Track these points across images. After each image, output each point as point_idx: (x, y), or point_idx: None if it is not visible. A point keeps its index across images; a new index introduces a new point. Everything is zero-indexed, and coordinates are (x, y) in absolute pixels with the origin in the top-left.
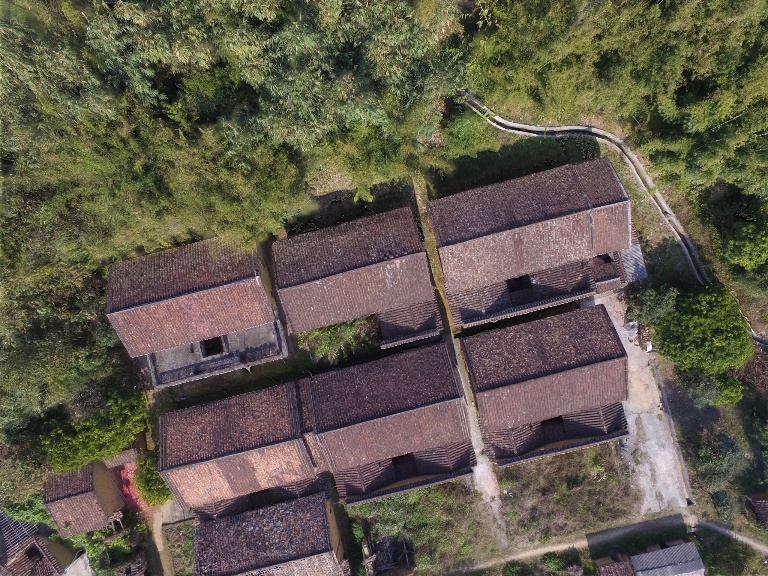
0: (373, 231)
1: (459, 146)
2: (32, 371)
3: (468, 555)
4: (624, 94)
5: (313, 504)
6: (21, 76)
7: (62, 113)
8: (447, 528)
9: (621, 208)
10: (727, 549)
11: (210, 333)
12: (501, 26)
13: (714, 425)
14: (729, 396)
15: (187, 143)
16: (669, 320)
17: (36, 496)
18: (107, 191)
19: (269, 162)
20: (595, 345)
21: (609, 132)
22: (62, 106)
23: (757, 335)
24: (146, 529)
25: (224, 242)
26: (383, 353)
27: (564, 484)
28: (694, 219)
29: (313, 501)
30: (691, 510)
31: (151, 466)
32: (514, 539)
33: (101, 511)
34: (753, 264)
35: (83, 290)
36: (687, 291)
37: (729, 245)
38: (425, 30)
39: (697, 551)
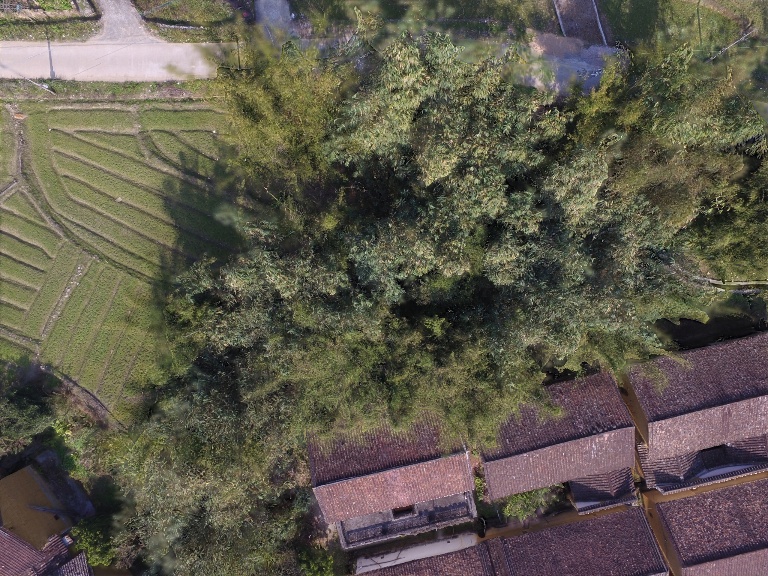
0: (575, 399)
1: None
2: (252, 558)
3: None
4: None
5: None
6: (278, 285)
7: (321, 324)
8: None
9: None
10: None
11: (409, 501)
12: (740, 221)
13: None
14: None
15: (456, 363)
16: None
17: None
18: (351, 392)
19: (517, 365)
20: None
21: None
22: (322, 318)
23: None
24: None
25: None
26: None
27: None
28: None
29: None
30: None
31: None
32: None
33: None
34: None
35: (282, 457)
36: None
37: None
38: (668, 227)
39: None
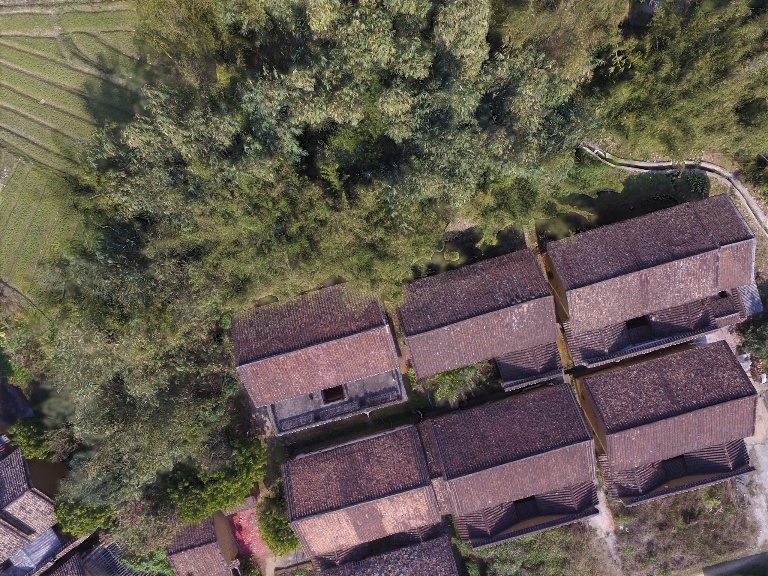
0: (496, 274)
1: (575, 185)
2: (172, 429)
3: None
4: (760, 136)
5: (438, 548)
6: (175, 140)
7: (217, 176)
8: (564, 566)
9: (746, 246)
10: None
11: (335, 381)
12: (639, 73)
13: None
14: None
15: (349, 205)
16: None
17: (158, 548)
18: (255, 250)
19: (418, 217)
20: (723, 383)
21: (719, 166)
22: (218, 170)
23: None
24: (259, 574)
25: (347, 289)
26: (495, 392)
27: (680, 518)
28: None
29: (437, 545)
30: None
31: (279, 516)
32: (631, 575)
33: (224, 561)
34: None
35: (207, 342)
36: None
37: None
38: (566, 80)
39: None
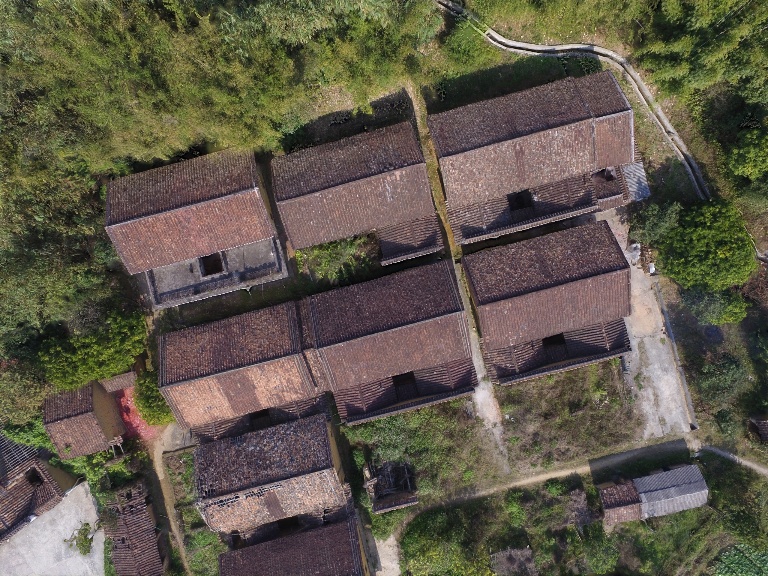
0: (373, 145)
1: (459, 61)
2: (30, 278)
3: (470, 481)
4: None
5: (314, 424)
6: None
7: (57, 3)
8: (449, 453)
9: (624, 118)
10: (731, 473)
11: (209, 249)
12: None
13: (718, 348)
14: (733, 313)
15: (184, 29)
16: (672, 237)
17: (36, 418)
18: (103, 88)
19: (267, 57)
20: (597, 258)
21: (611, 50)
22: None
23: (761, 255)
24: (147, 457)
25: (223, 157)
26: None
27: (566, 409)
28: (697, 136)
29: (314, 421)
30: (694, 435)
31: (151, 383)
32: (516, 465)
33: (101, 432)
34: (757, 172)
35: (81, 206)
36: (690, 206)
37: (733, 155)
38: None
39: (700, 473)
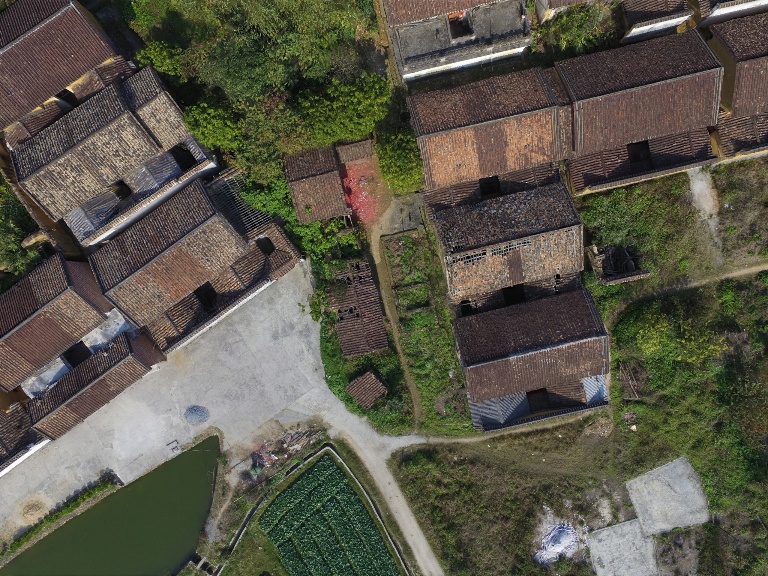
0: None
1: None
2: None
3: (685, 270)
4: None
5: (555, 190)
6: None
7: None
8: (667, 240)
9: None
10: None
11: (470, 2)
12: None
13: None
14: None
15: None
16: None
17: (278, 178)
18: None
19: None
20: None
21: None
22: None
23: None
24: (365, 240)
25: None
26: None
27: None
28: None
29: (554, 188)
30: None
31: None
32: (732, 254)
33: (343, 194)
34: None
35: None
36: None
37: None
38: None
39: None
